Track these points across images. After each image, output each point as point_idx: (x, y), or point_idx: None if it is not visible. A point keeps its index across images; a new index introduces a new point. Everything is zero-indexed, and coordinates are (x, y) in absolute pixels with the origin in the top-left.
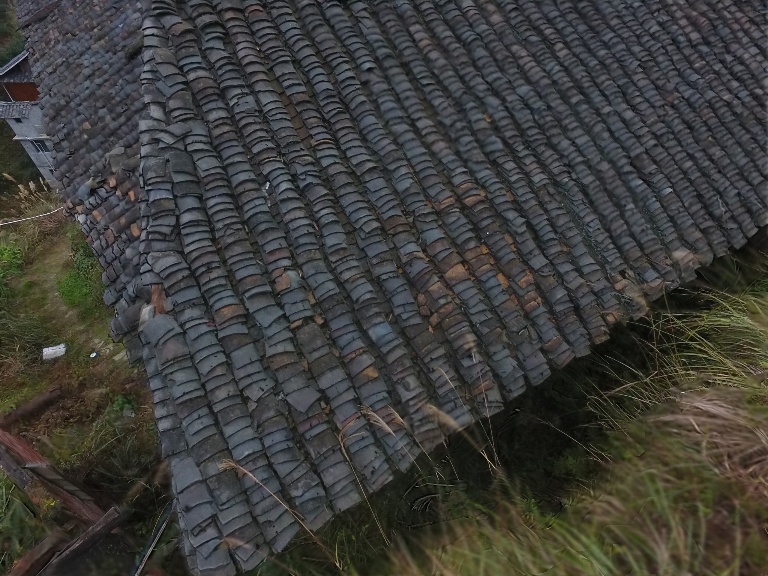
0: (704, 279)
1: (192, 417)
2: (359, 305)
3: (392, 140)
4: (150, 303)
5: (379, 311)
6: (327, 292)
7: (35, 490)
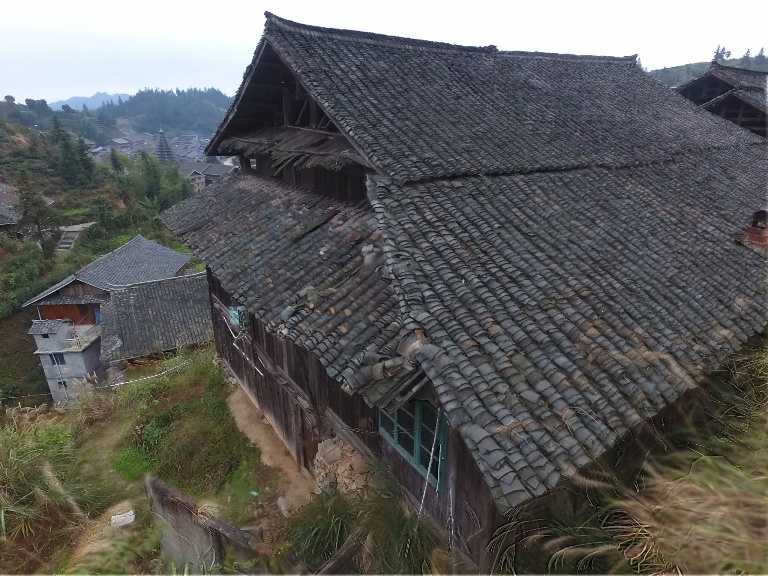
0: (748, 350)
1: (470, 399)
2: (543, 345)
3: None
4: None
5: (556, 349)
6: (522, 336)
7: (258, 544)
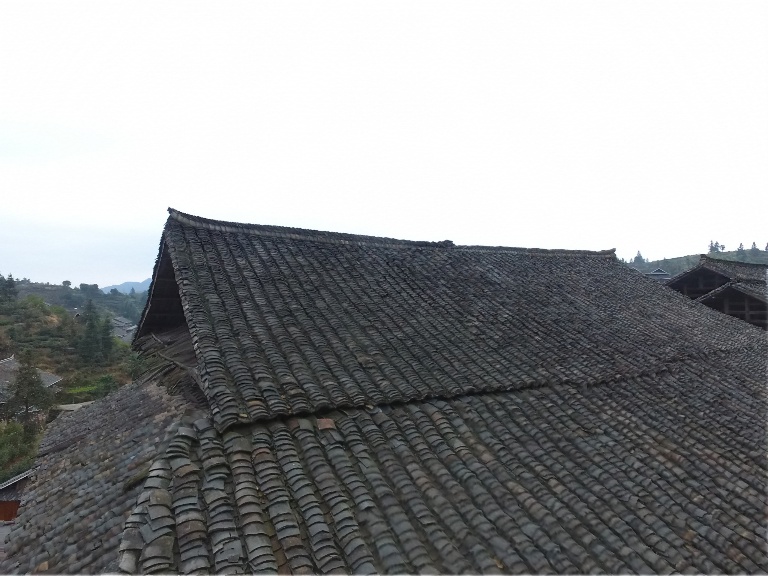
0: None
1: None
2: None
3: None
4: None
5: None
6: None
7: None
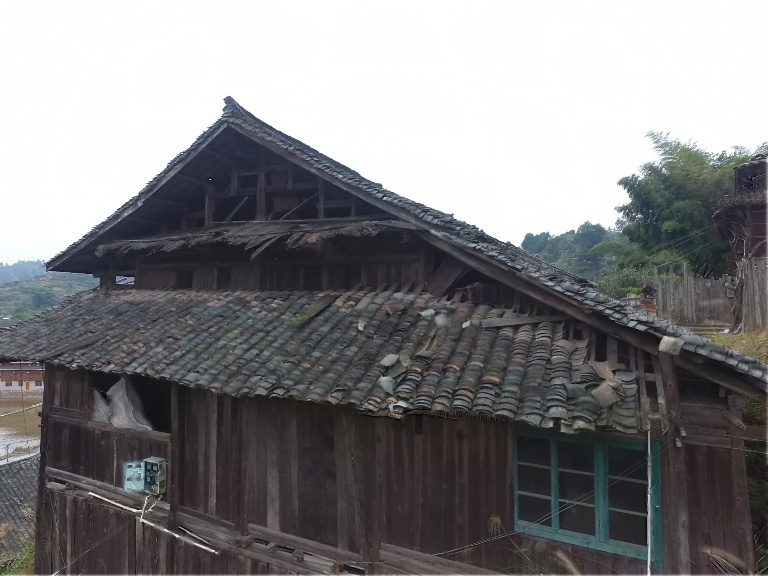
0: None
1: None
2: None
3: None
4: (600, 385)
5: None
6: None
7: None
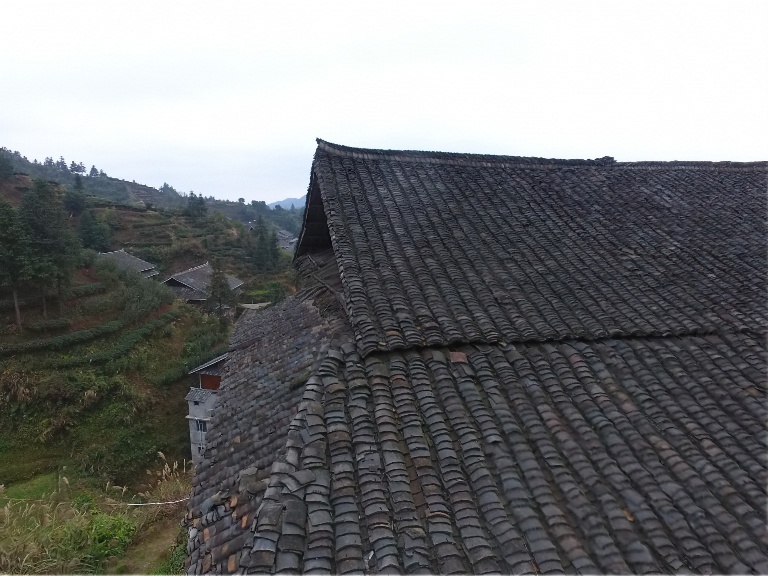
0: None
1: None
2: None
3: (514, 524)
4: None
5: None
6: None
7: None
